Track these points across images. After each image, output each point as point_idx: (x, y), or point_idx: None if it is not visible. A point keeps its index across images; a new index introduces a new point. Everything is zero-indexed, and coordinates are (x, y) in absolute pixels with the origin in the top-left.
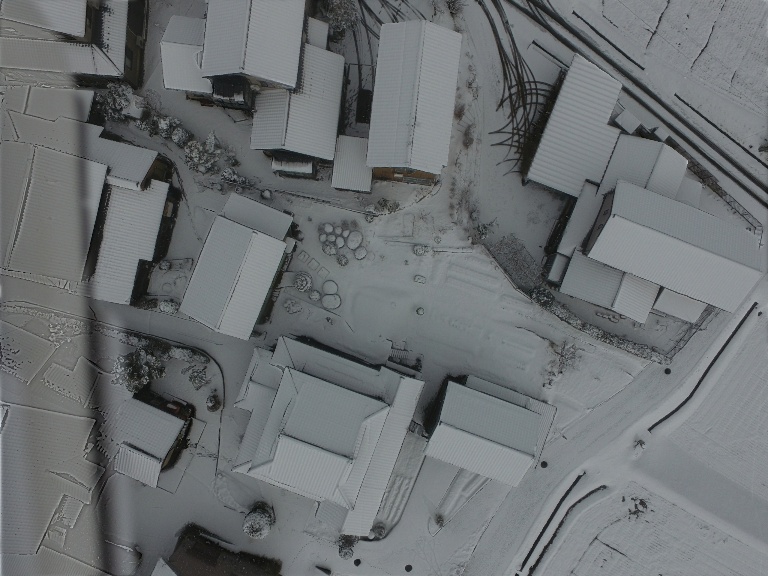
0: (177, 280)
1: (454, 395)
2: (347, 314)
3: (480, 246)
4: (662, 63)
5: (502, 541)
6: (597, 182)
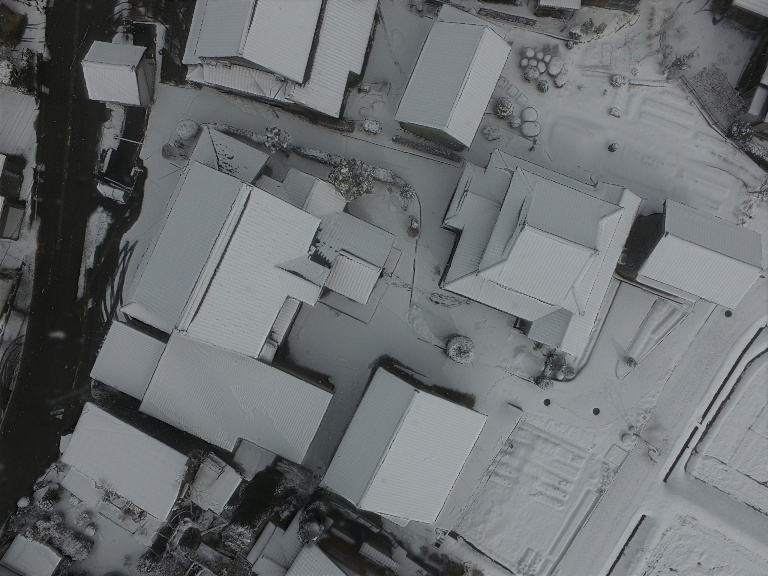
0: (375, 104)
1: (674, 211)
2: (545, 143)
3: (676, 81)
4: None
5: (685, 391)
6: None
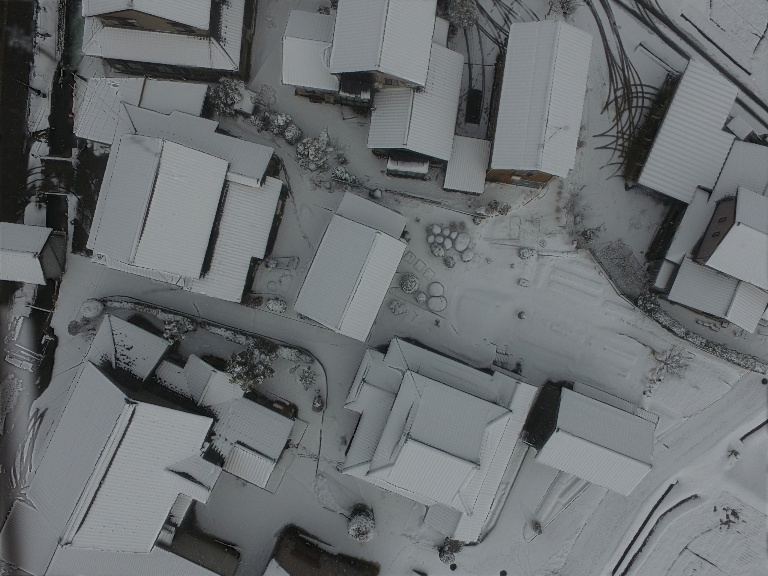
0: (282, 278)
1: (569, 402)
2: (452, 317)
3: (585, 251)
4: None
5: (594, 548)
6: (710, 189)
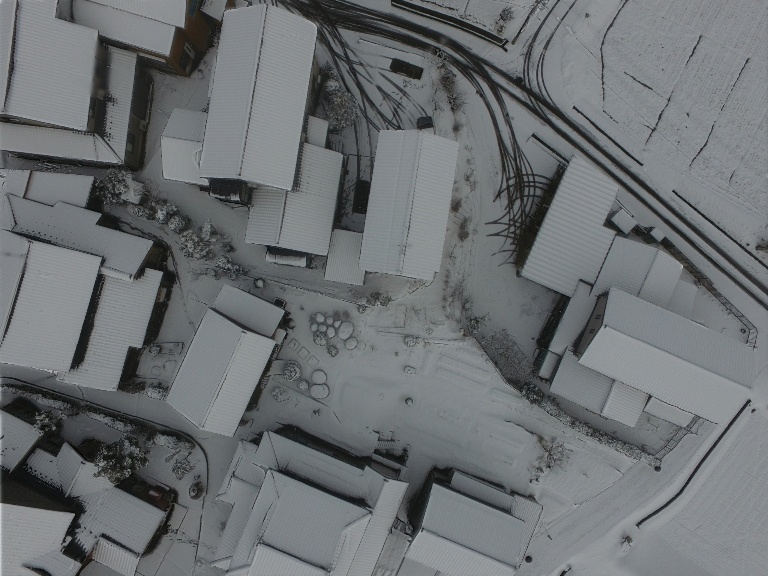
0: (166, 363)
1: (438, 499)
2: (335, 404)
3: (472, 338)
4: (661, 160)
5: None
6: (591, 283)
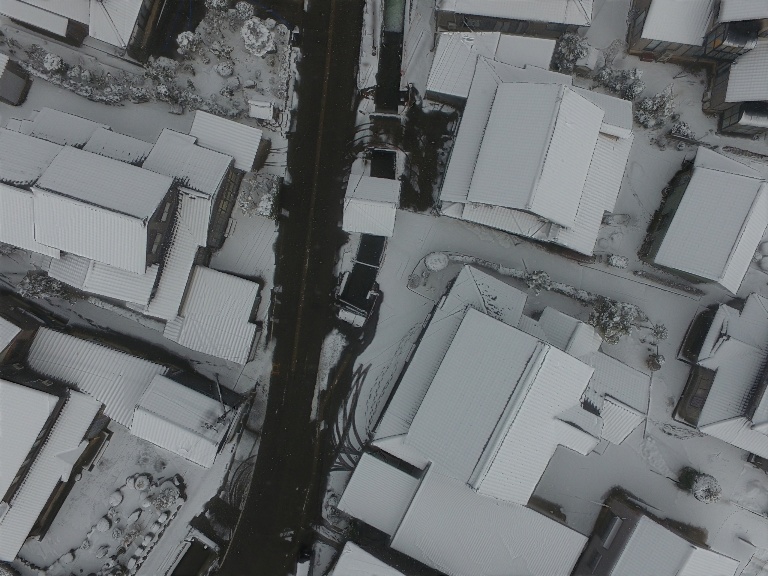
0: (614, 236)
1: None
2: None
3: None
4: None
5: None
6: None
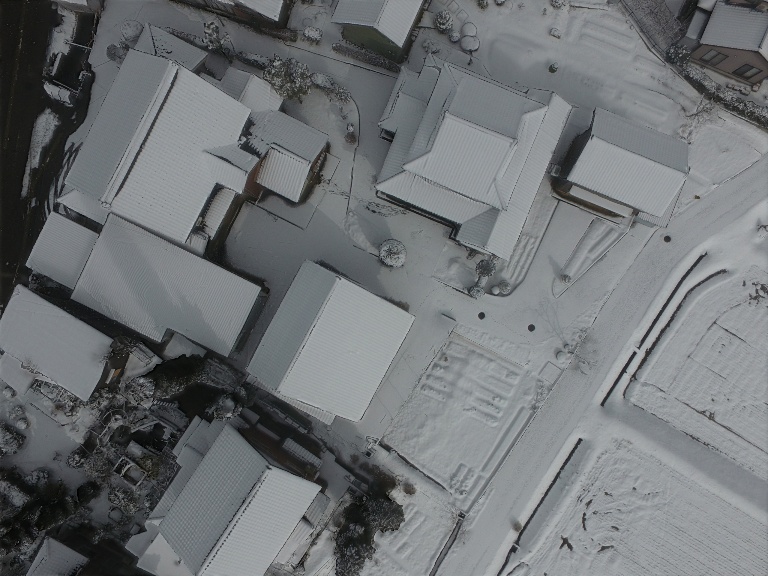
0: (318, 15)
1: (603, 117)
2: (484, 59)
3: (616, 4)
4: None
5: (622, 314)
6: None
